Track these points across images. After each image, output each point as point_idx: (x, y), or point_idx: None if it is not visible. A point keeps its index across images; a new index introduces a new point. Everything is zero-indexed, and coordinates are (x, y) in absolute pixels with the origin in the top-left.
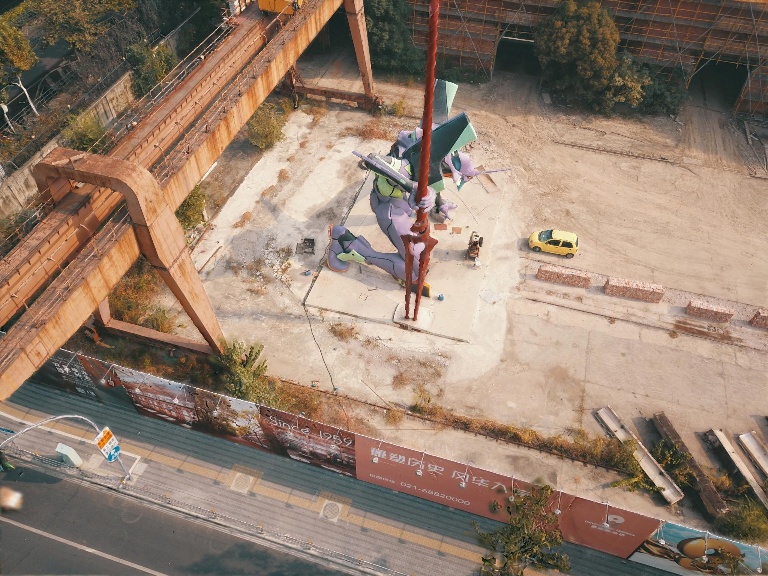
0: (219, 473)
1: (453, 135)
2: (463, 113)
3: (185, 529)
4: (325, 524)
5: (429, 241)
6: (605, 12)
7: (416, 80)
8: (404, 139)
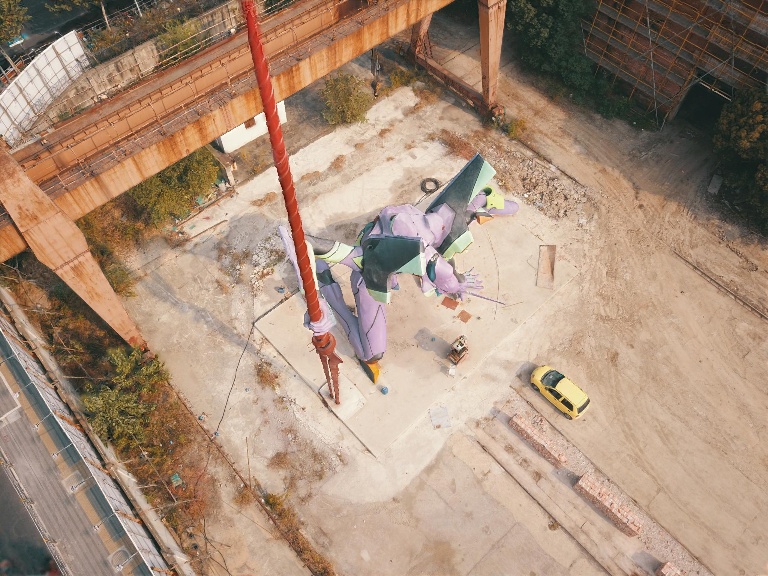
0: (64, 461)
1: (405, 255)
2: (419, 238)
3: (8, 496)
4: (106, 568)
5: (332, 357)
6: None
7: (567, 95)
8: (384, 219)
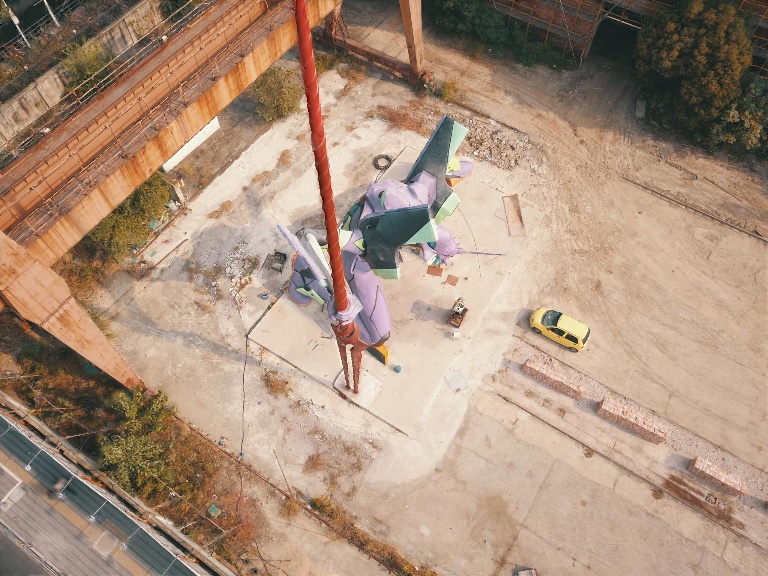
0: (88, 525)
1: (412, 226)
2: (426, 205)
3: None
4: None
5: (357, 344)
6: (740, 23)
7: (486, 51)
8: (372, 197)
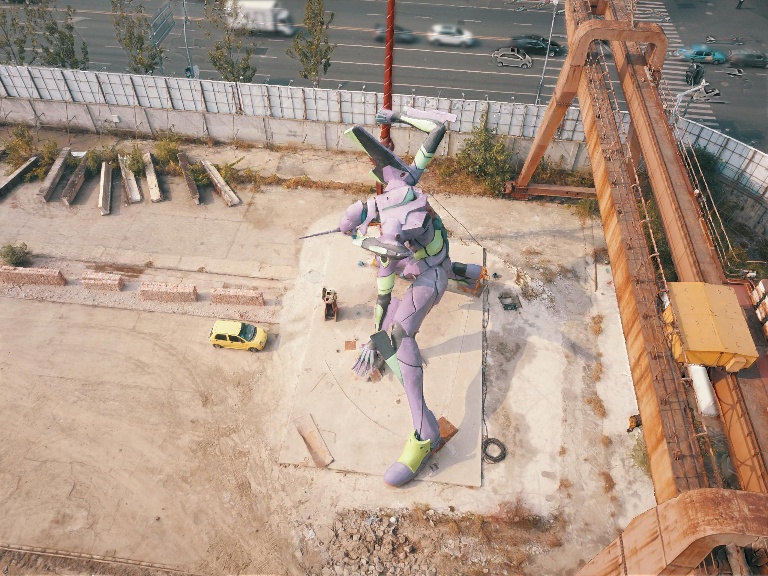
0: None
1: None
2: None
3: None
4: None
5: None
6: None
7: None
8: None
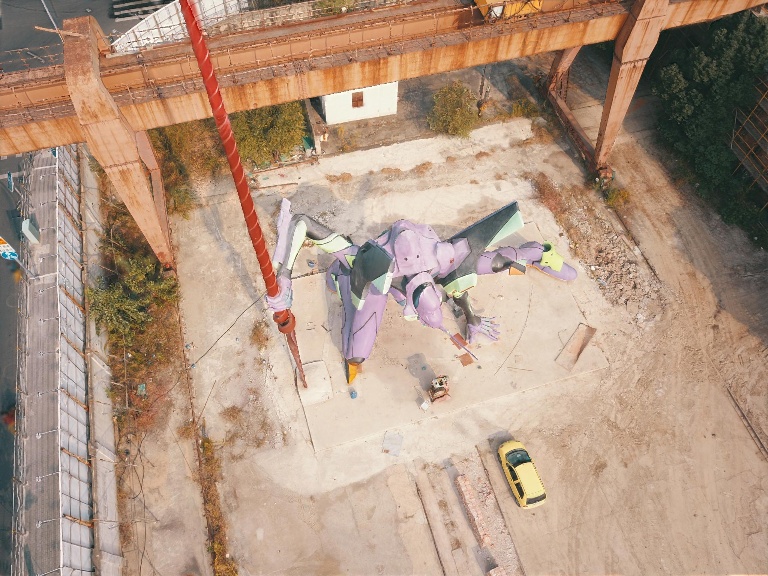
0: None
1: (380, 269)
2: (392, 257)
3: (15, 341)
4: (52, 435)
5: (289, 337)
6: None
7: (693, 183)
8: (394, 229)
